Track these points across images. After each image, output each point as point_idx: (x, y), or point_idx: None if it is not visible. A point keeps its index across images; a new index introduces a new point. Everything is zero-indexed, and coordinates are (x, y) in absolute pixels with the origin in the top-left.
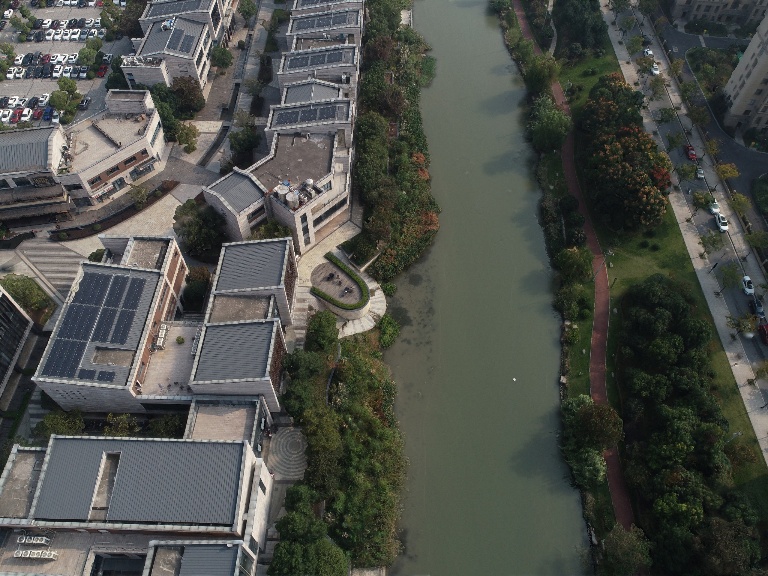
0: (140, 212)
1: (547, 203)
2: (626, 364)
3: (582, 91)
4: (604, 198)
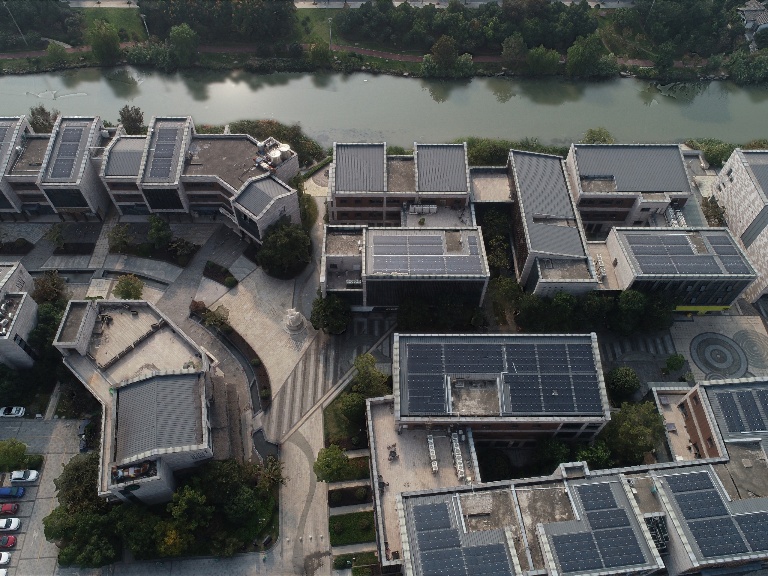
0: None
1: (256, 63)
2: (397, 44)
3: (126, 31)
4: (269, 25)
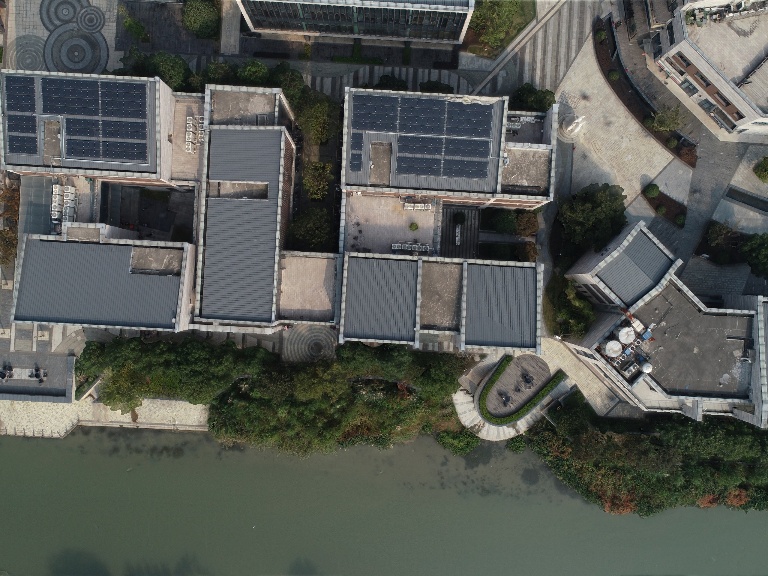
0: (641, 124)
1: None
2: None
3: None
4: None
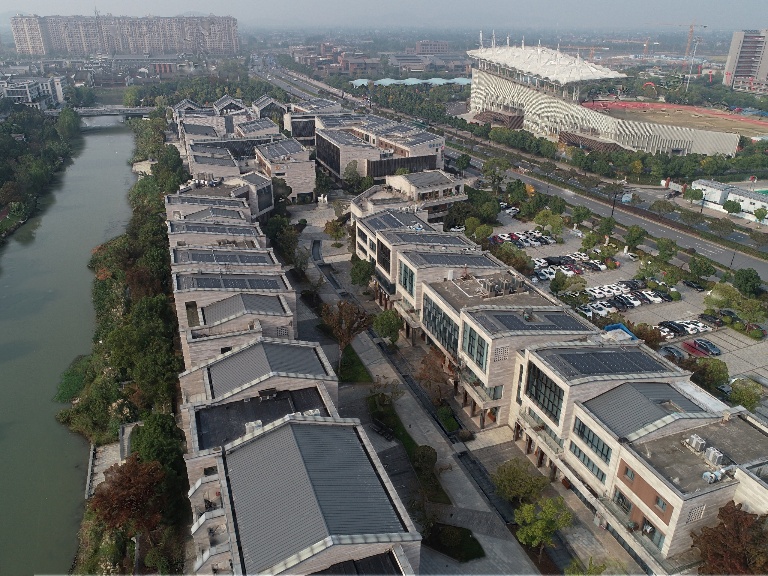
0: None
1: None
2: None
3: None
4: None
